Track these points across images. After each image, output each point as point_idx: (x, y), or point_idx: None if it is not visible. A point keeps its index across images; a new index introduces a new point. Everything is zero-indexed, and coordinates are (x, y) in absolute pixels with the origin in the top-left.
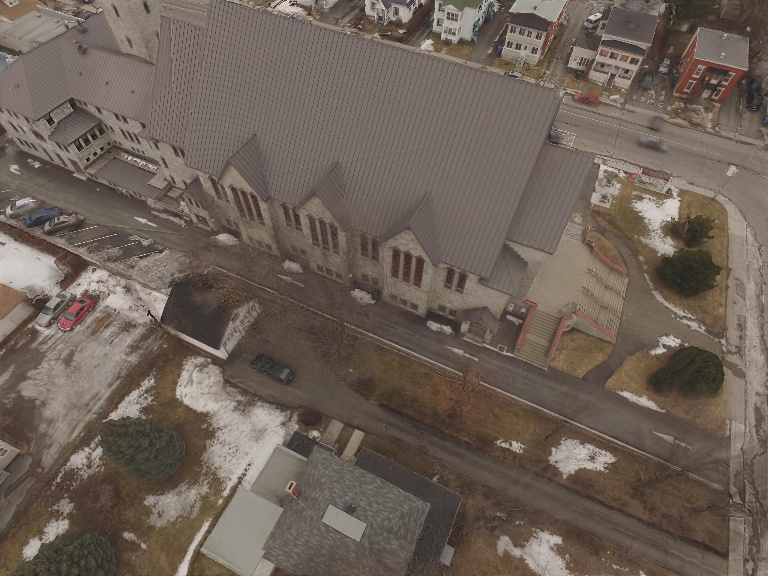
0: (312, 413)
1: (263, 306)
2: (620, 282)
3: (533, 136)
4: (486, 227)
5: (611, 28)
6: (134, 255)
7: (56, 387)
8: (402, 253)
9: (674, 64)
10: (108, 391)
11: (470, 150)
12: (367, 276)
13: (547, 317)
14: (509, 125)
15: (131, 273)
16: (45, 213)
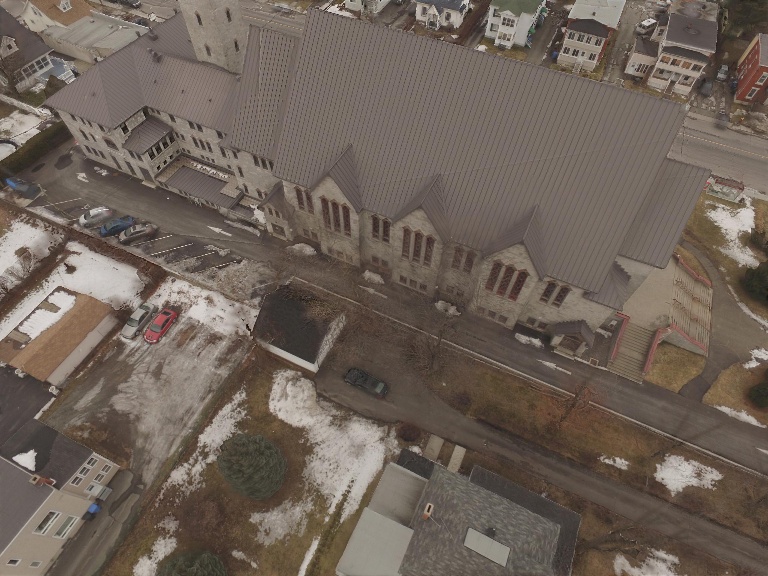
0: (410, 428)
1: (348, 318)
2: (706, 294)
3: (654, 150)
4: (597, 241)
5: (672, 34)
6: (212, 265)
7: (148, 401)
8: (504, 266)
9: (731, 70)
10: (201, 405)
11: (584, 163)
12: (452, 288)
13: (640, 330)
14: (628, 139)
15: (212, 284)
16: (120, 222)
